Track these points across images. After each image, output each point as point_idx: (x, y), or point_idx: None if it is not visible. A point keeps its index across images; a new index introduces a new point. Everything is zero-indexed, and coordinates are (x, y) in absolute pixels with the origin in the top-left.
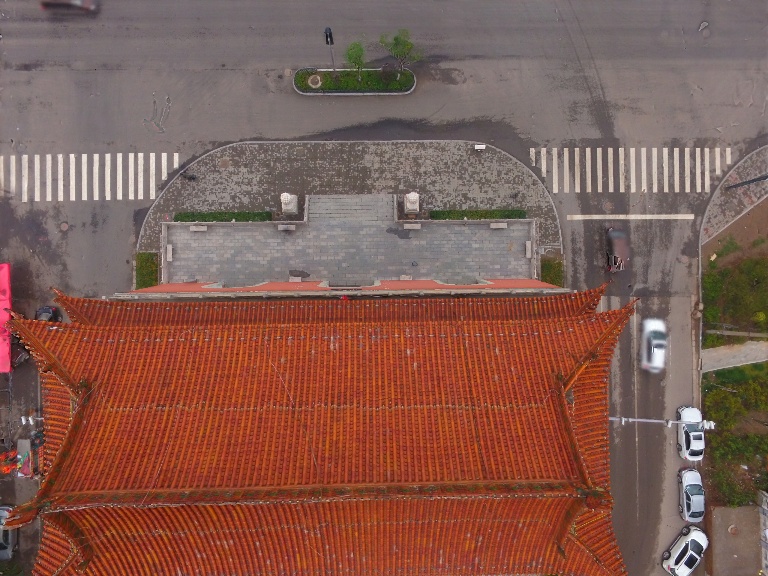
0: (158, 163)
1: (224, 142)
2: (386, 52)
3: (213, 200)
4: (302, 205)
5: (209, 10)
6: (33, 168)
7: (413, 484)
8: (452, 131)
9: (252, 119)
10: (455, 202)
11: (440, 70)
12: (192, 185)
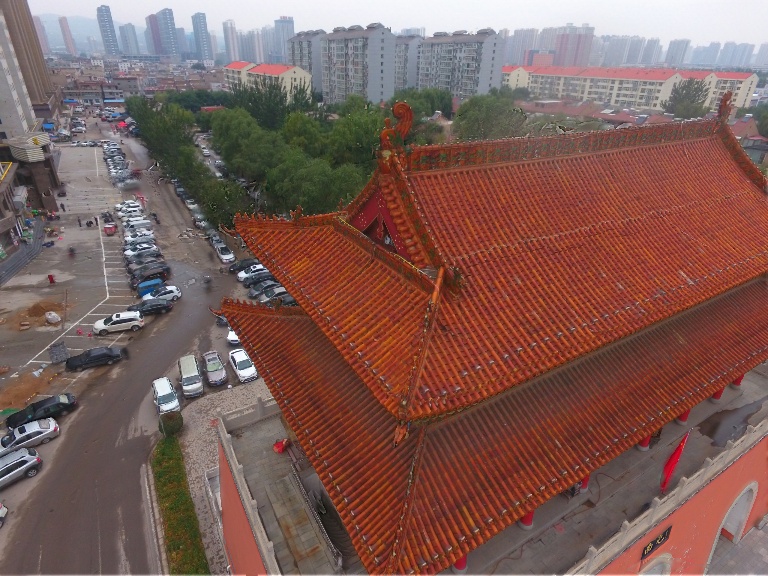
0: None
1: None
2: None
3: None
4: None
5: None
6: None
7: (538, 159)
8: None
9: None
10: None
11: None
12: None
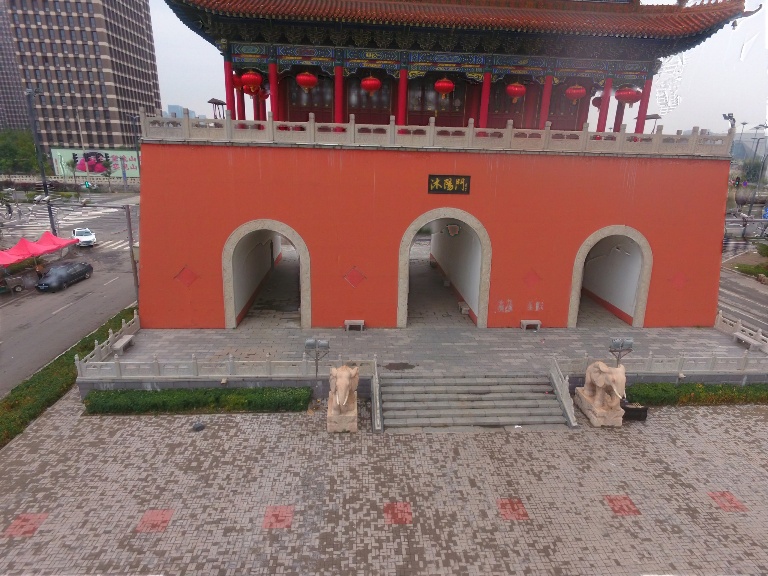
0: None
1: None
2: None
3: None
4: None
5: None
6: (135, 242)
7: None
8: None
9: None
10: None
11: None
12: None
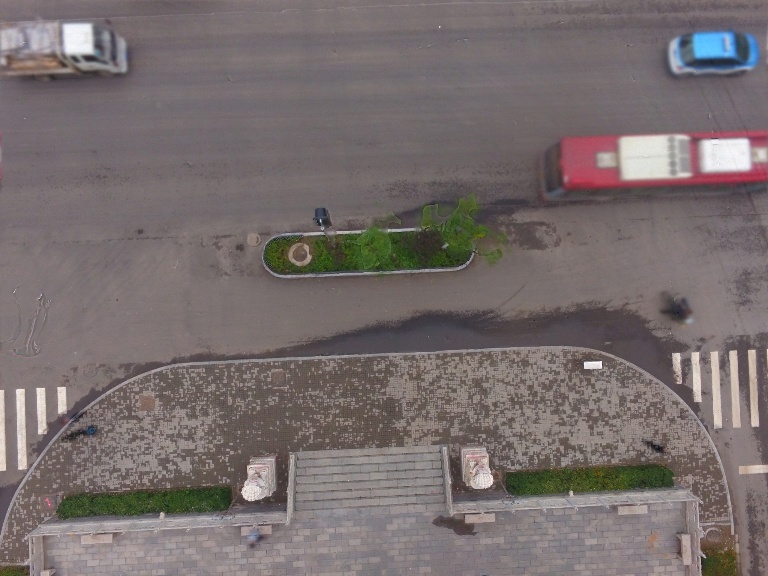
0: (30, 406)
1: (145, 364)
2: (422, 198)
3: (128, 468)
4: (284, 471)
5: (113, 136)
6: None
7: None
8: (538, 329)
9: (193, 322)
10: (548, 454)
11: (515, 225)
12: (91, 443)
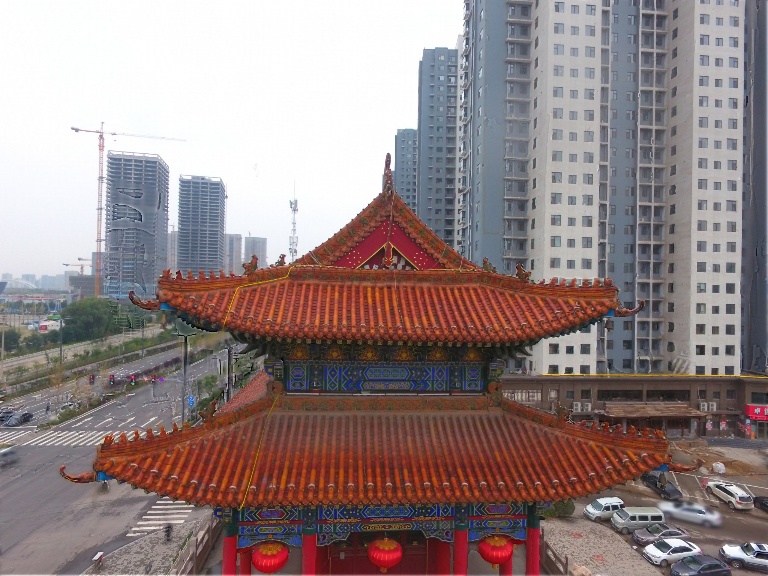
0: None
1: None
2: None
3: None
4: None
5: None
6: None
7: None
8: None
9: None
10: None
11: None
12: None
